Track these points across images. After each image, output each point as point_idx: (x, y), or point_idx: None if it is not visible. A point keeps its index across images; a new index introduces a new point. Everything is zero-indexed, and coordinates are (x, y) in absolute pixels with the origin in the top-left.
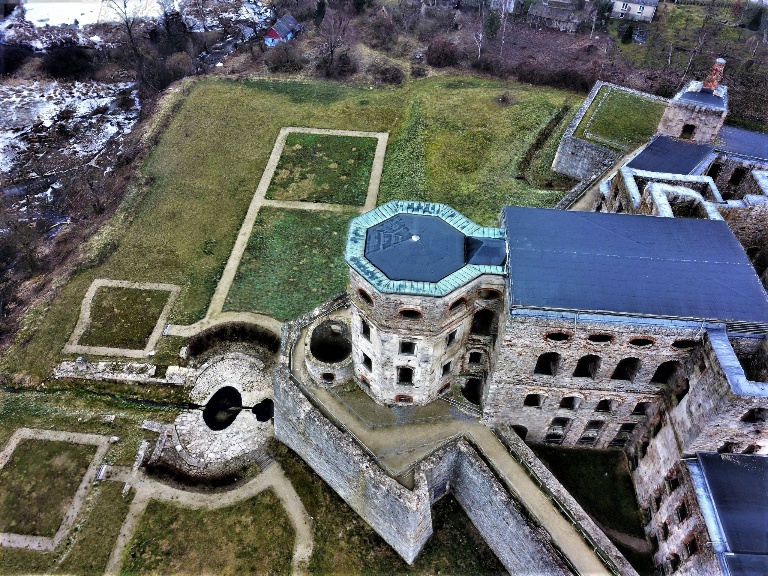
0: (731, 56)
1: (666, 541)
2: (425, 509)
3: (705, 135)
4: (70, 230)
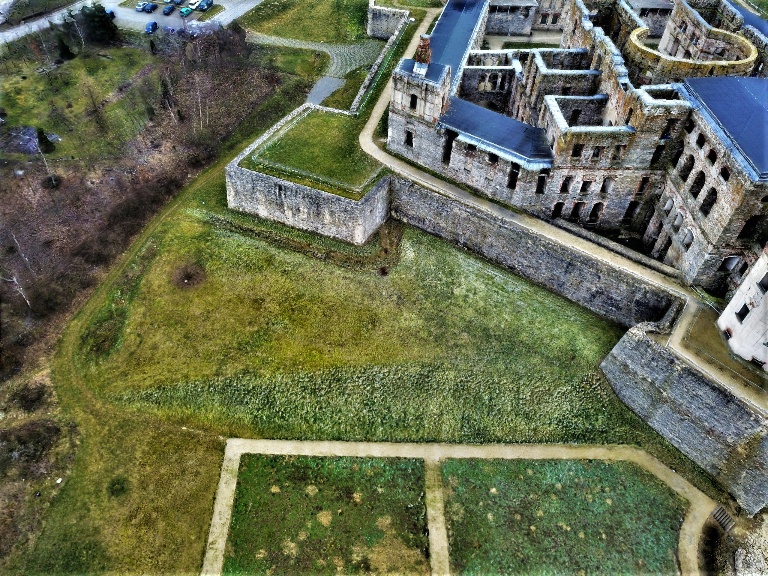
0: (124, 84)
1: None
2: None
3: None
4: None
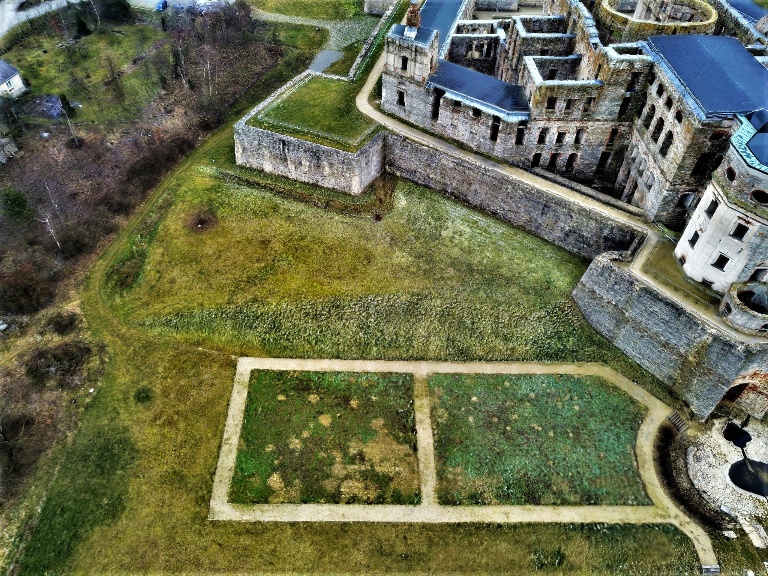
0: (138, 57)
1: None
2: None
3: None
4: None
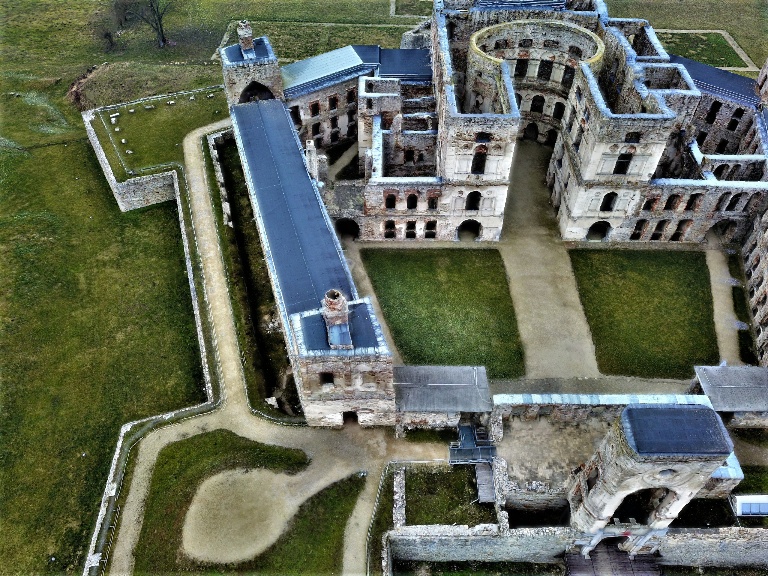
0: None
1: None
2: (409, 46)
3: (764, 88)
4: None
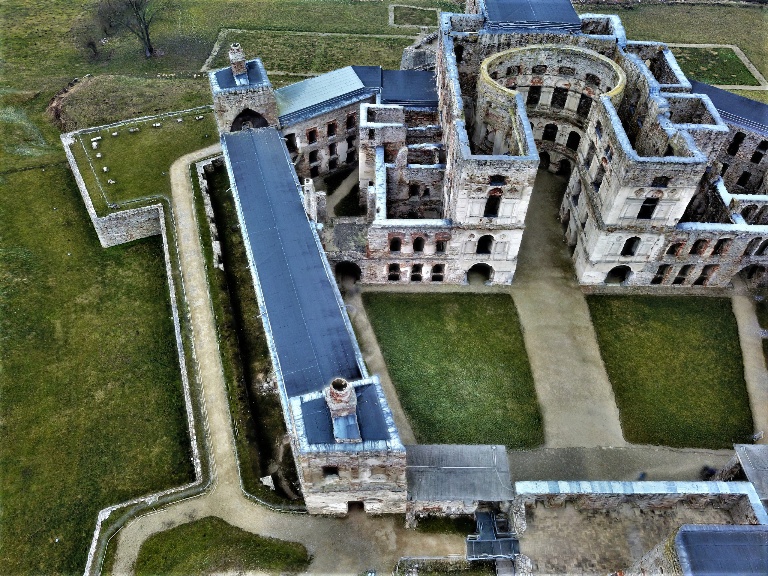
0: None
1: None
2: (410, 62)
3: None
4: (576, 3)
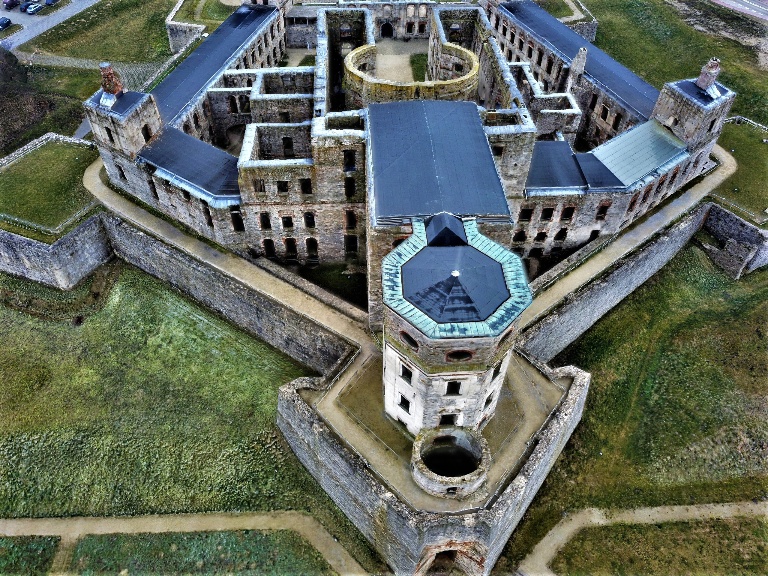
0: None
1: (548, 237)
2: None
3: (155, 124)
4: None
